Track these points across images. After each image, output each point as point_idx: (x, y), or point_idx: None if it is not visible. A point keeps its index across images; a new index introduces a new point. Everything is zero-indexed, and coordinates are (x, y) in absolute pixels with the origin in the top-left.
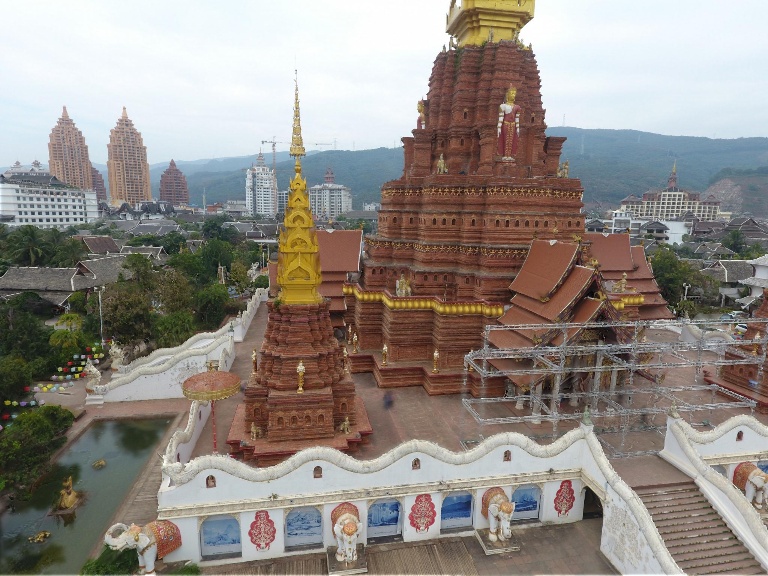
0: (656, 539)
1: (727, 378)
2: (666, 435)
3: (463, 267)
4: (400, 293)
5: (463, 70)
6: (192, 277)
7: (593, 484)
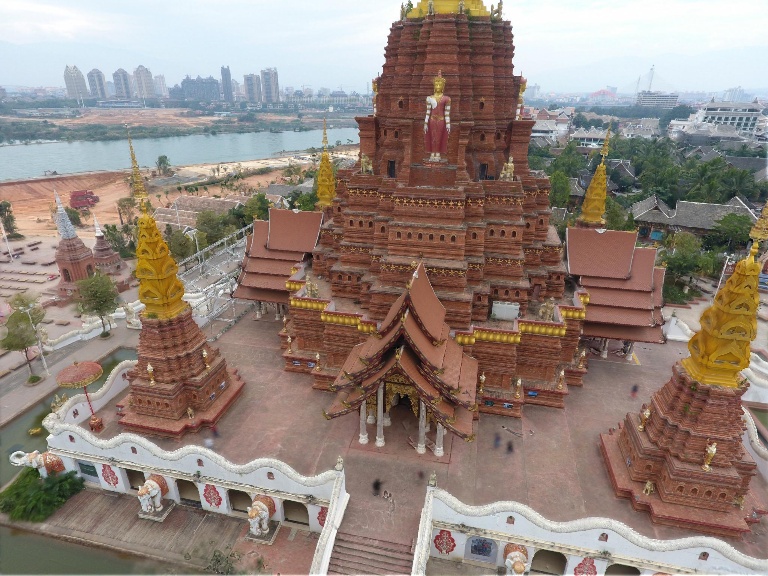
0: None
1: None
2: None
3: None
4: None
5: None
6: (697, 239)
7: None
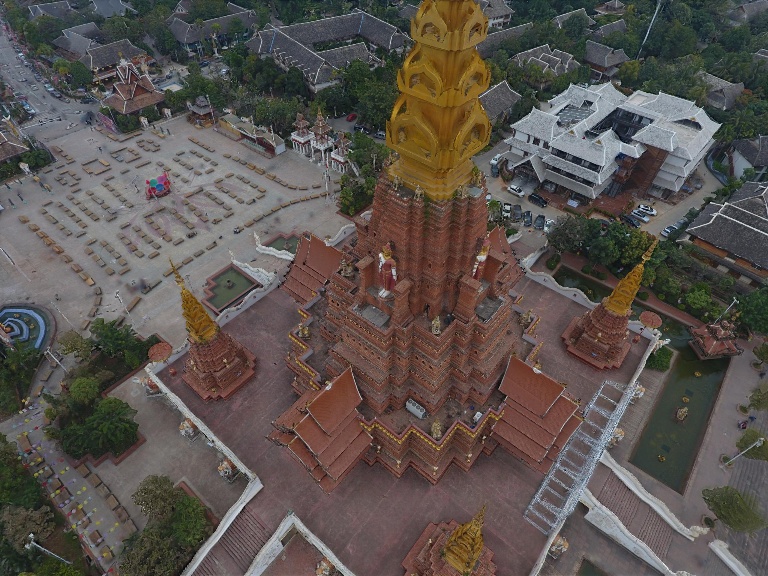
0: (623, 528)
1: (578, 348)
2: None
3: (460, 380)
4: (436, 433)
5: (443, 232)
6: None
7: (584, 502)
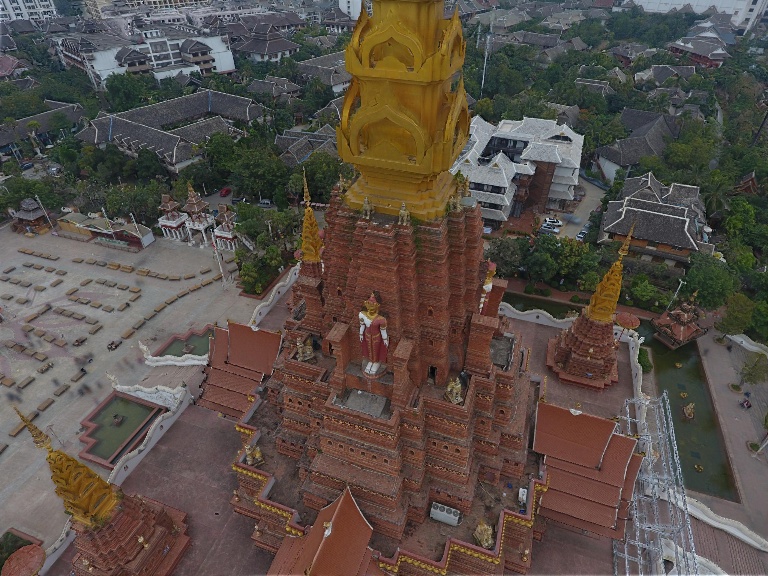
0: (722, 573)
1: (570, 372)
2: None
3: (487, 455)
4: None
5: None
6: None
7: None
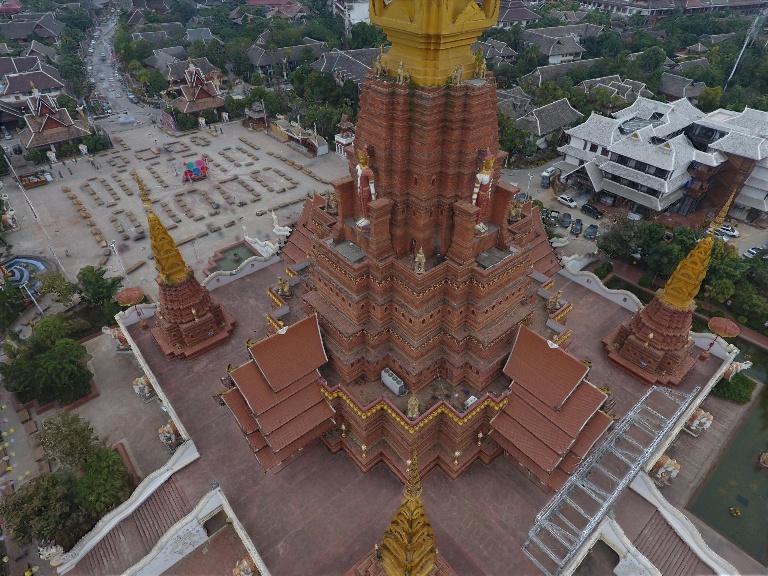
0: None
1: (623, 355)
2: (637, 478)
3: (452, 352)
4: (412, 411)
5: (430, 129)
6: None
7: (613, 546)
